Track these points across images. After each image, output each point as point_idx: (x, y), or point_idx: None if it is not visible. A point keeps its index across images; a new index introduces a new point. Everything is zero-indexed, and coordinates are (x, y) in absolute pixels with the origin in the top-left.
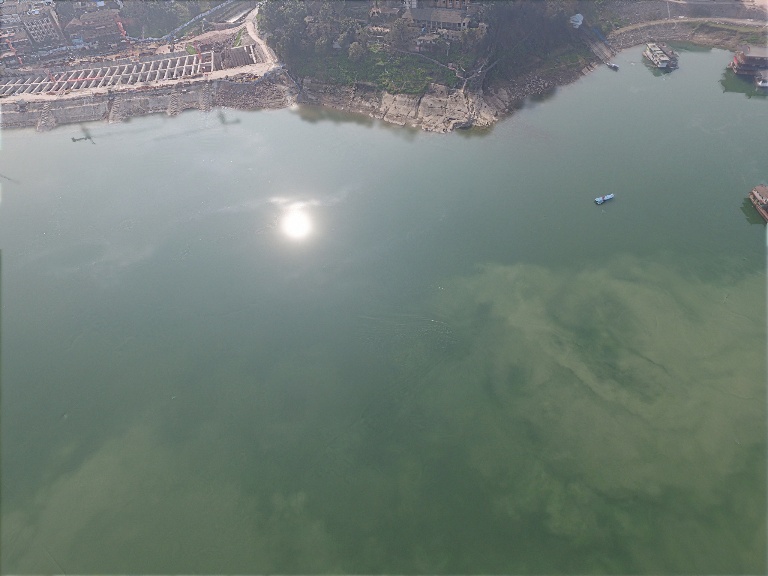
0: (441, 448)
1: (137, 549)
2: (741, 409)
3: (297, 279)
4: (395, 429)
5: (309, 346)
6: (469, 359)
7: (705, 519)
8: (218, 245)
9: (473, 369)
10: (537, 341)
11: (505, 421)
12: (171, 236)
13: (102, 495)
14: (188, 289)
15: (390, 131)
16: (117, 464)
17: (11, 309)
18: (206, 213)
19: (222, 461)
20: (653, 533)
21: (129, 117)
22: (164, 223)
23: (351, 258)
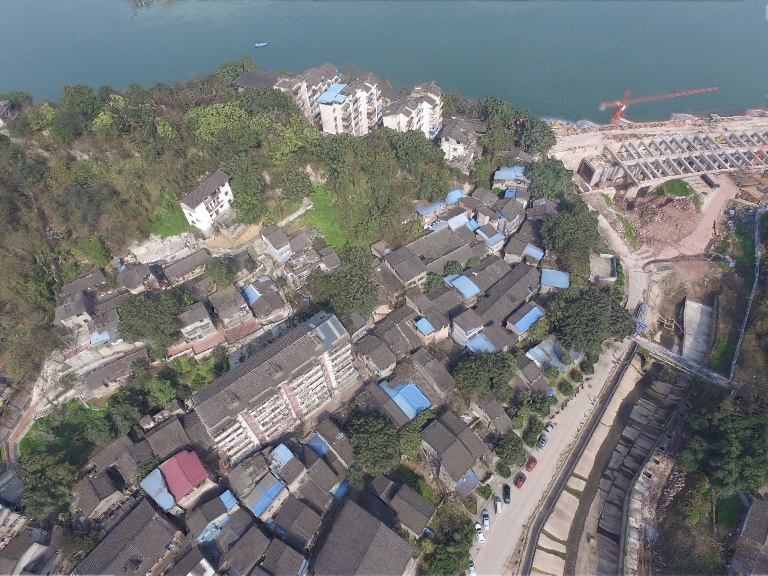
0: None
1: None
2: None
3: (448, 22)
4: None
5: None
6: None
7: None
8: None
9: None
10: None
11: None
12: (534, 38)
13: None
14: None
15: (387, 92)
16: None
17: (596, 14)
18: None
19: None
20: None
21: (670, 120)
22: None
23: (420, 27)
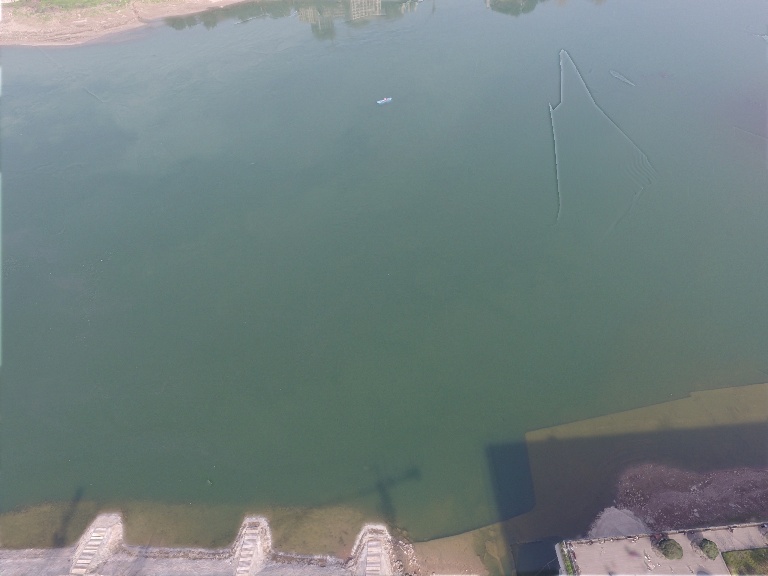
0: None
1: (63, 100)
2: None
3: None
4: None
5: None
6: None
7: None
8: None
9: None
10: None
11: None
12: None
13: None
14: None
15: None
16: (73, 128)
17: (128, 190)
18: None
19: None
20: None
21: None
22: None
23: None
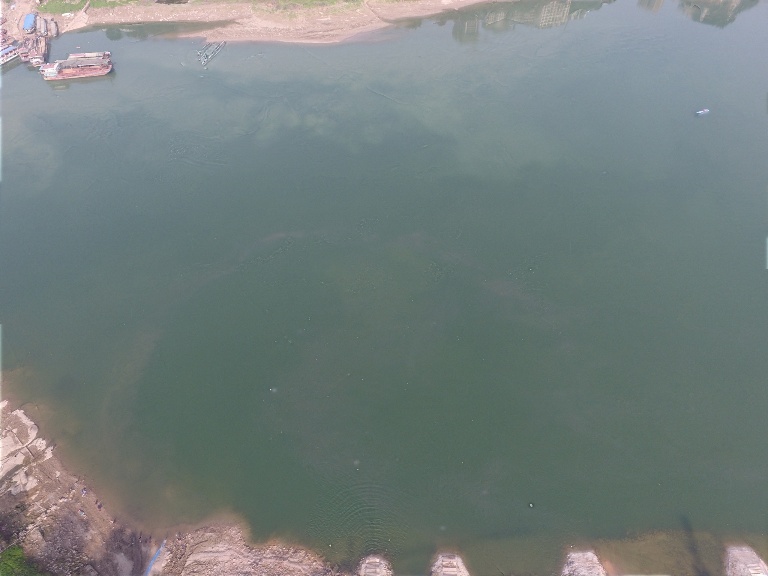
0: (212, 107)
1: (363, 99)
2: (53, 113)
3: (263, 196)
4: (233, 127)
5: (266, 152)
6: (170, 132)
7: (118, 94)
8: (333, 237)
9: (171, 130)
10: (122, 133)
11: (173, 112)
12: (383, 251)
13: (390, 119)
14: (358, 201)
15: (50, 399)
16: (386, 128)
17: (505, 196)
18: (351, 282)
19: (329, 126)
20: (144, 92)
21: (558, 575)
22: (392, 262)
23: (211, 206)
